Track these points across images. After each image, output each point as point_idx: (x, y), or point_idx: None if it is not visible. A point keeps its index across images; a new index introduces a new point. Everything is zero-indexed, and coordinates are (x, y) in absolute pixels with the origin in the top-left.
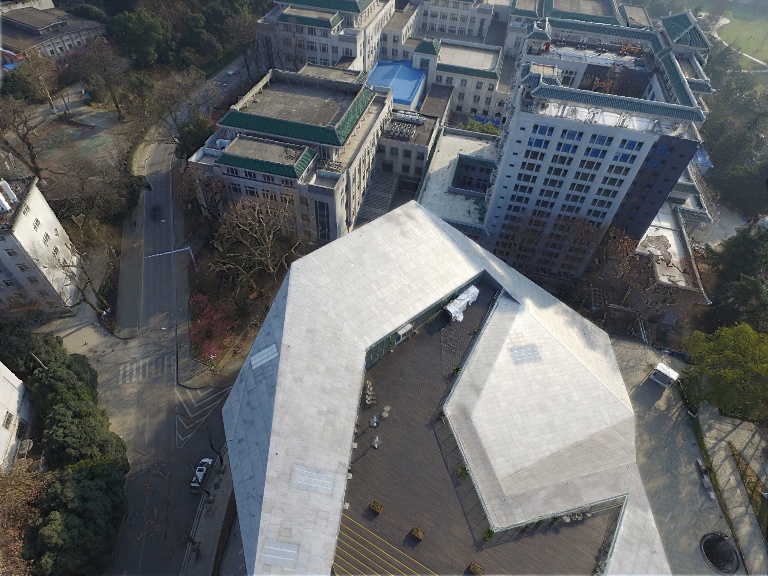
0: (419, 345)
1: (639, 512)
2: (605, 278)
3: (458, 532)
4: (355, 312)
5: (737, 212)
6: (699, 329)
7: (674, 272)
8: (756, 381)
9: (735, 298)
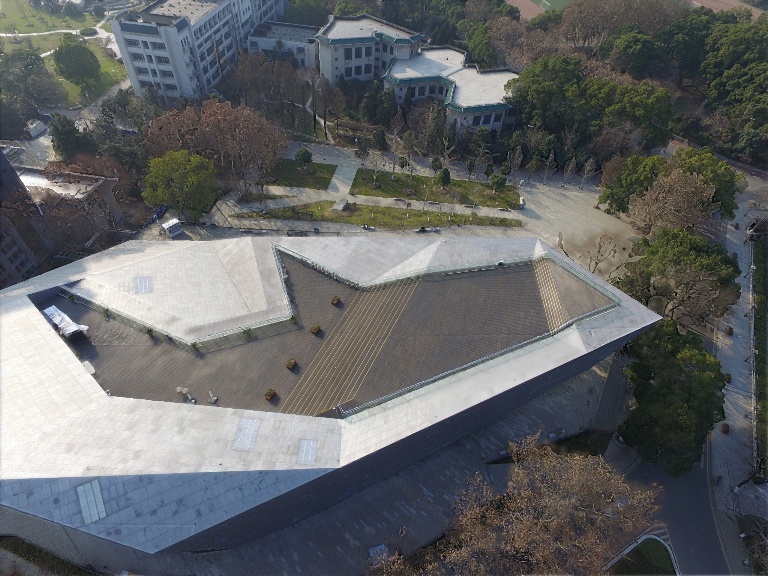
0: (108, 365)
1: (283, 242)
2: (50, 242)
3: (291, 339)
4: (52, 406)
5: (11, 140)
6: (131, 204)
7: (74, 188)
8: (200, 171)
9: (115, 168)
